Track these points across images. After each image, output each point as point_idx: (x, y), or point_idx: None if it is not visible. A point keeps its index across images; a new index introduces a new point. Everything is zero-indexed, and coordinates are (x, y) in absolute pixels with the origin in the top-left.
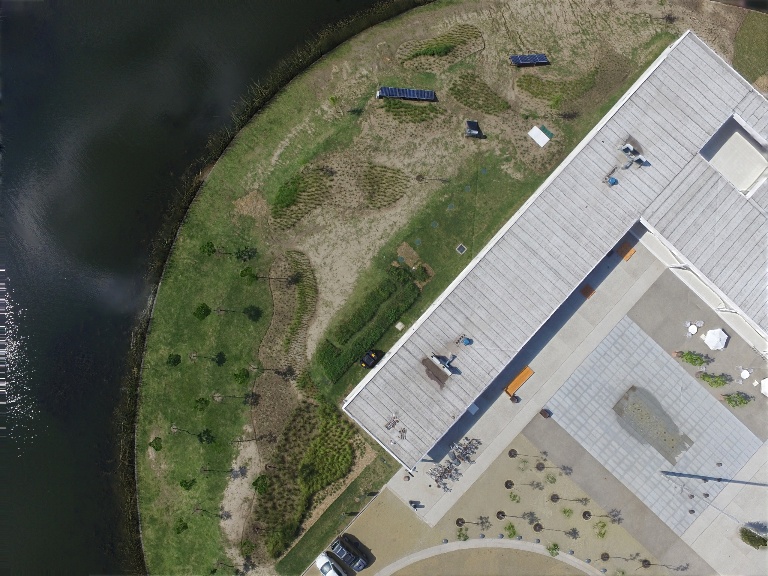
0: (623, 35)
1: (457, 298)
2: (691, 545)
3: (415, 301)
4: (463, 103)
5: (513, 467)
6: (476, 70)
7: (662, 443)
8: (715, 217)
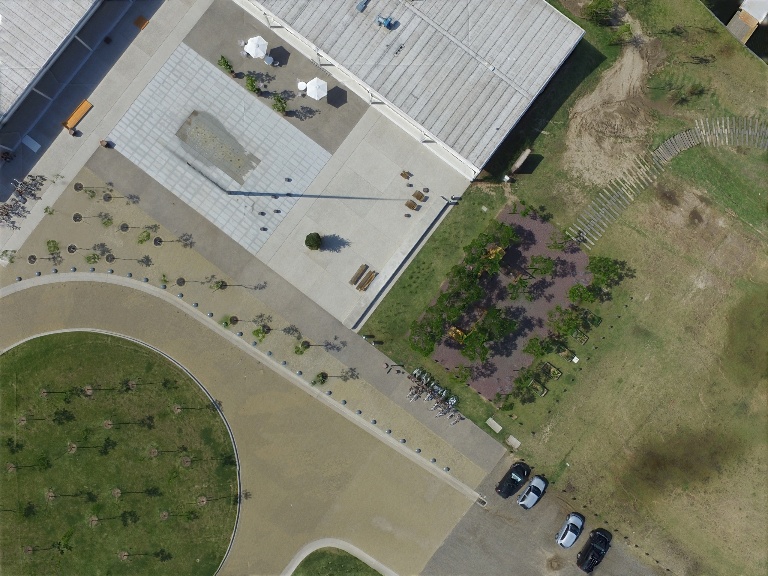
0: None
1: None
2: (267, 263)
3: None
4: None
5: (80, 200)
6: None
7: (228, 164)
8: None
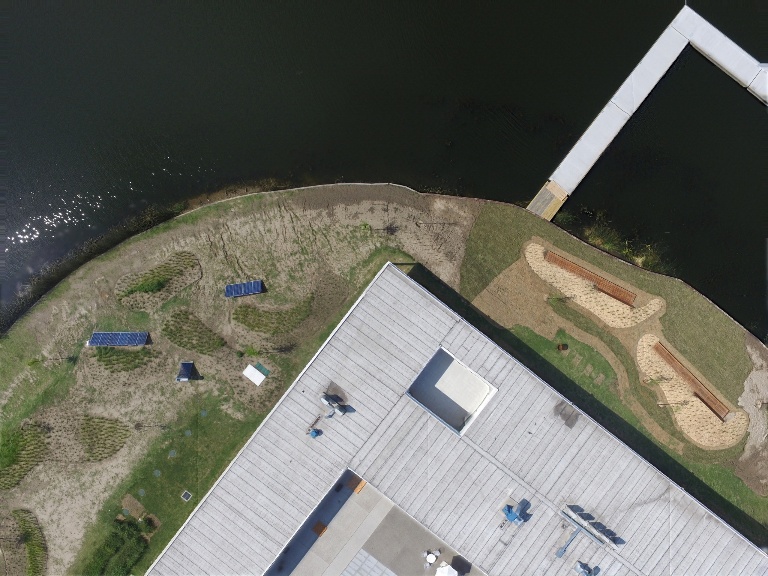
0: (342, 253)
1: (164, 567)
2: None
3: (143, 553)
4: (177, 344)
5: None
6: (190, 306)
7: None
8: (427, 459)
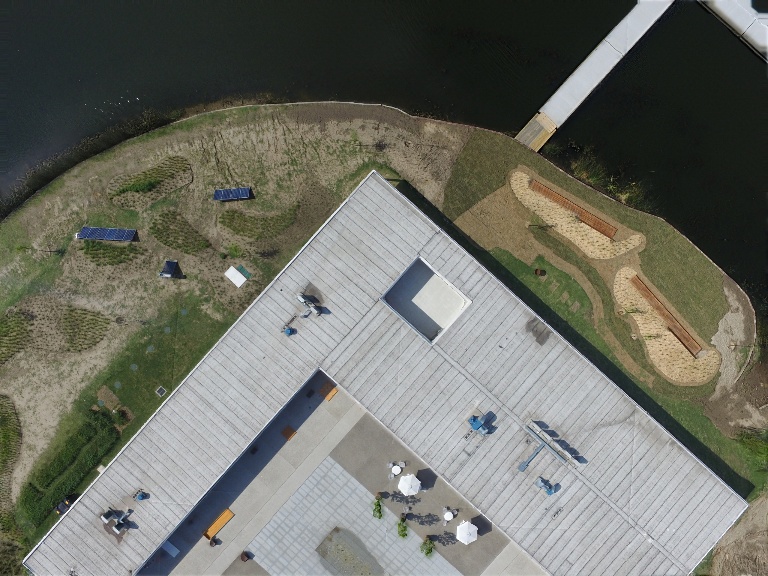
0: (330, 165)
1: (133, 452)
2: None
3: (115, 445)
4: (163, 243)
5: None
6: (179, 207)
7: None
8: (397, 365)
